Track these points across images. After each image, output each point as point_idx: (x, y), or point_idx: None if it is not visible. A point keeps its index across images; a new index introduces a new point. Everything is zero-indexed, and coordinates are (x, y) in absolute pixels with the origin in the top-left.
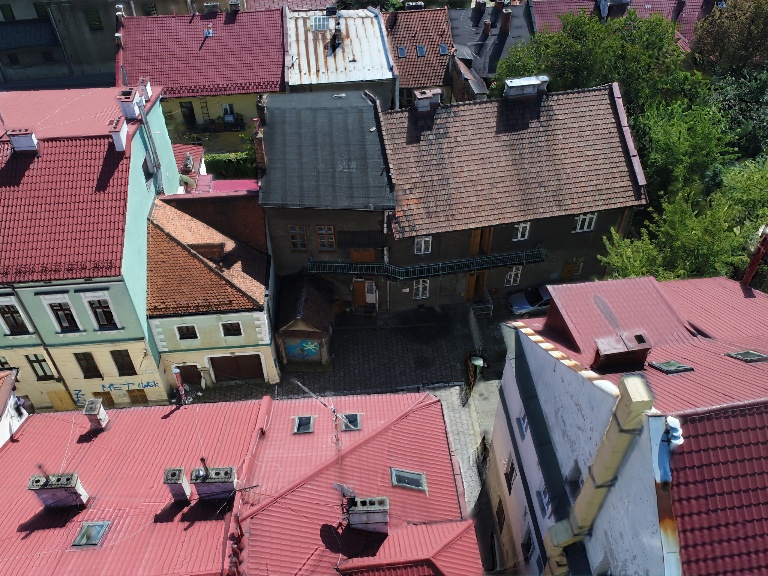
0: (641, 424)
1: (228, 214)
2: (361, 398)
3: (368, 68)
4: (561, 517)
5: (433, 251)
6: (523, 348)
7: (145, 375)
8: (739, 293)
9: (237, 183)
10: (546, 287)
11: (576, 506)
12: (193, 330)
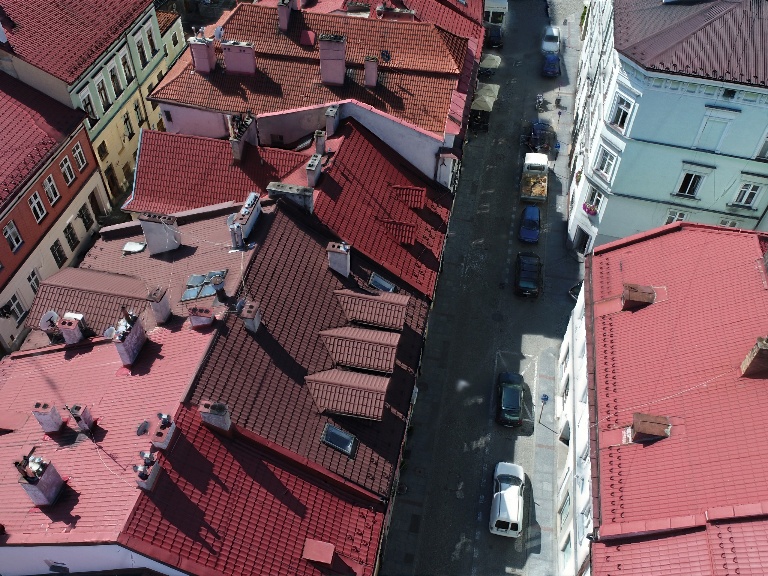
0: None
1: None
2: None
3: None
4: None
5: None
6: None
7: None
8: None
9: None
10: None
11: None
12: (164, 51)
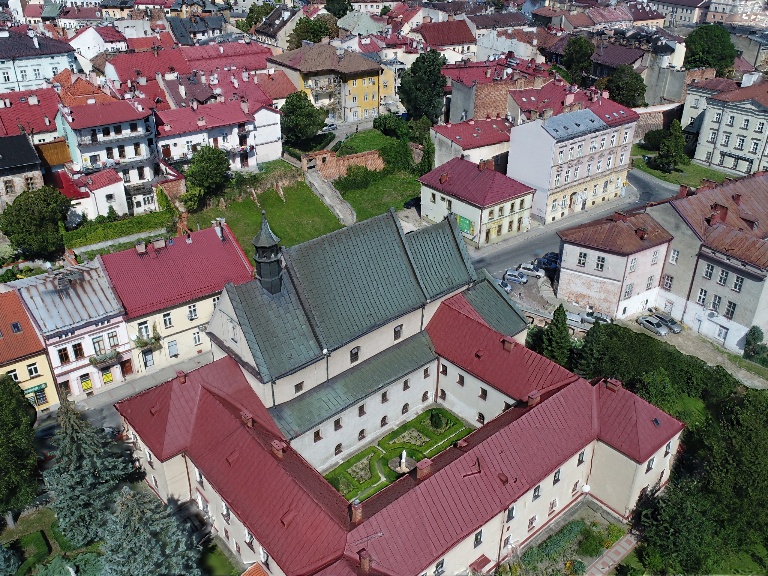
0: None
1: None
2: None
3: None
4: None
5: None
6: None
7: None
8: None
9: None
10: None
11: None
12: None
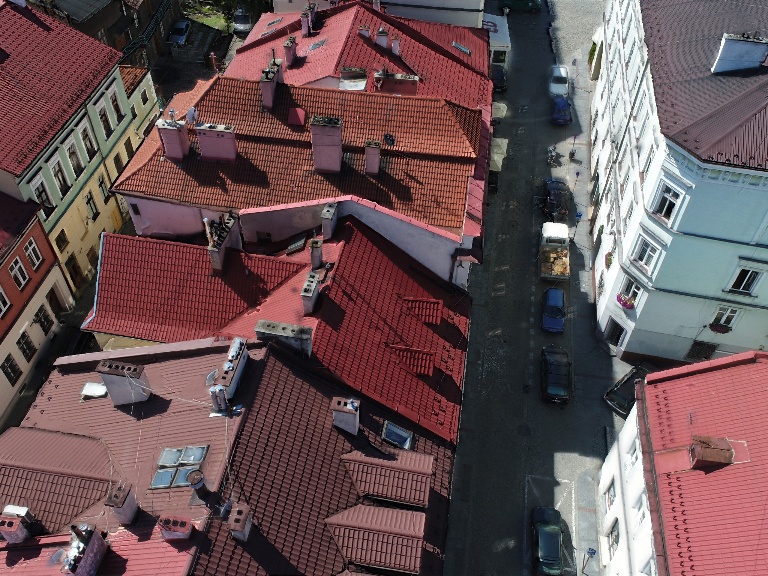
0: None
1: None
2: None
3: None
4: None
5: None
6: None
7: None
8: None
9: None
10: None
11: None
12: (132, 112)
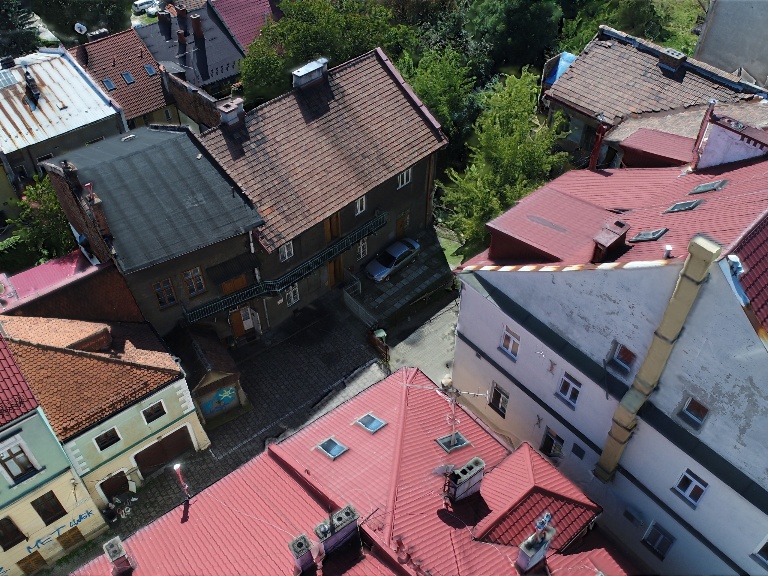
0: (707, 273)
1: (86, 298)
2: (354, 402)
3: (85, 110)
4: (617, 392)
5: (296, 253)
6: (491, 284)
7: (76, 509)
8: (598, 176)
9: (34, 272)
10: (486, 225)
11: (643, 372)
12: (112, 434)
